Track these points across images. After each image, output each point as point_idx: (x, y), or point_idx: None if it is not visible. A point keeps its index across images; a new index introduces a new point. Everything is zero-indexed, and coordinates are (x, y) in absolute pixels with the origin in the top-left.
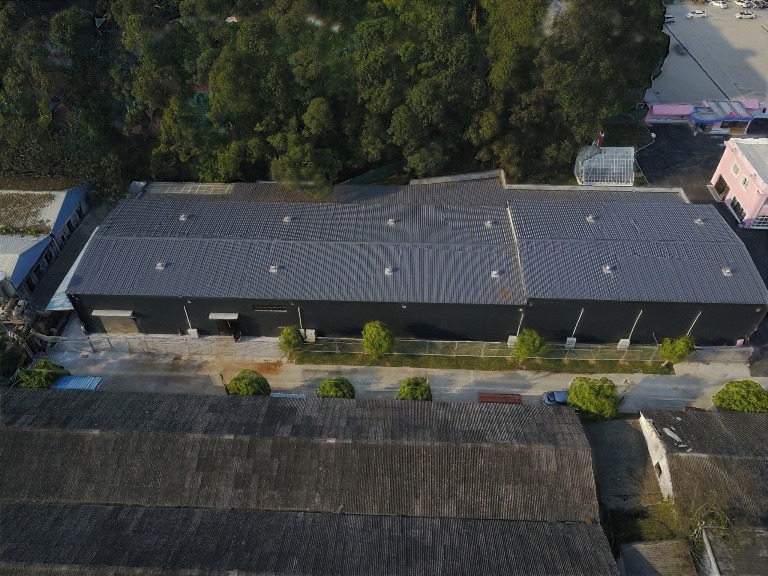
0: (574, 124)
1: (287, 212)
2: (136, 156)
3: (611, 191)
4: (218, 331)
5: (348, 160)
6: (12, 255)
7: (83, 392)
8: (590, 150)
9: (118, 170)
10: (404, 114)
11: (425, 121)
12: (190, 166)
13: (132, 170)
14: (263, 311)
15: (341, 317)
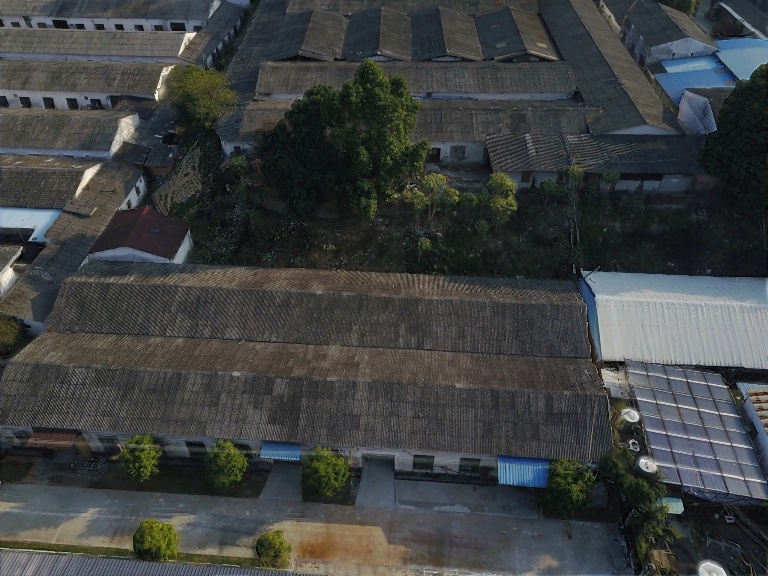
0: None
1: None
2: None
3: None
4: None
5: None
6: None
7: (505, 451)
8: None
9: None
10: None
11: None
12: None
13: None
14: None
15: None
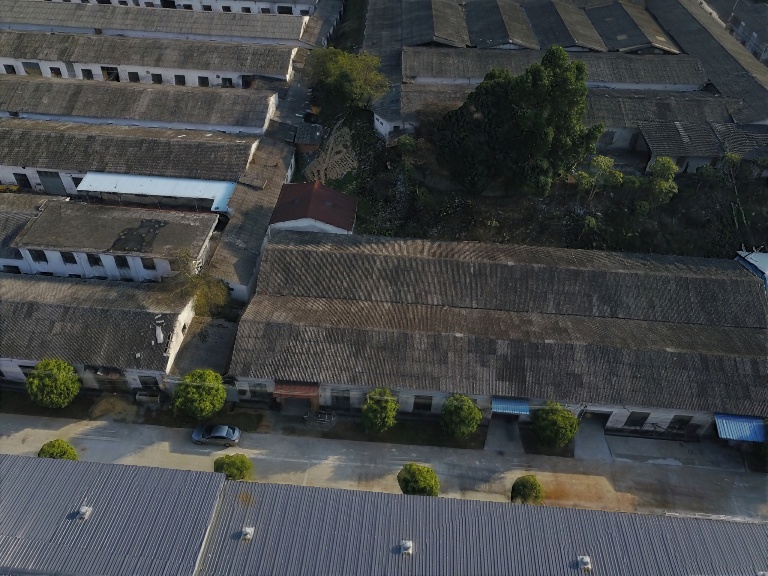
0: None
1: None
2: None
3: None
4: None
5: None
6: None
7: (721, 408)
8: None
9: None
10: None
11: None
12: None
13: None
14: None
15: None
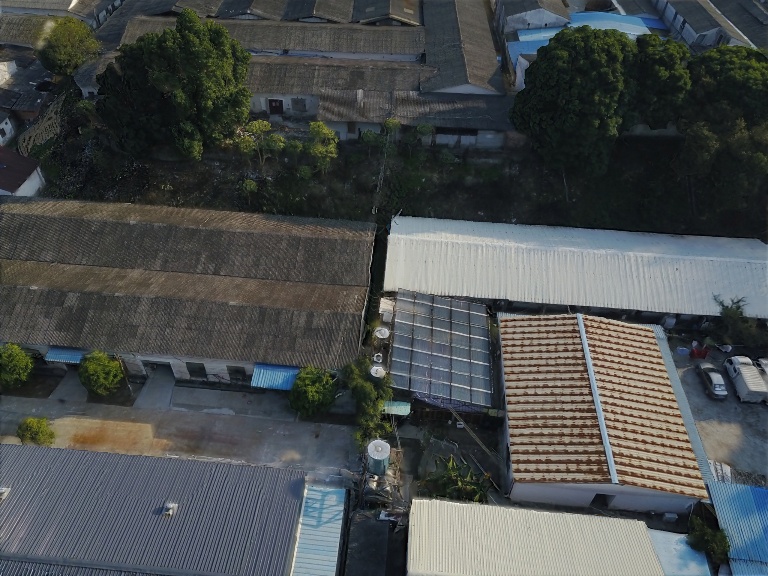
0: None
1: None
2: None
3: None
4: None
5: None
6: (419, 571)
7: (261, 359)
8: None
9: None
10: None
11: None
12: None
13: None
14: None
15: None
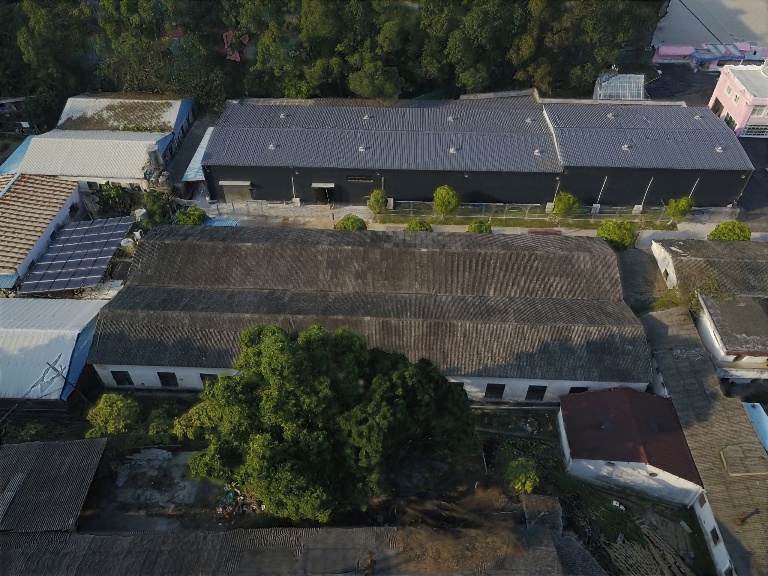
0: (596, 48)
1: (365, 113)
2: (230, 78)
3: (626, 104)
4: (316, 201)
5: (405, 84)
6: (150, 142)
7: (228, 227)
8: (608, 72)
9: (222, 84)
10: (459, 36)
11: (475, 42)
12: (278, 84)
13: (227, 89)
14: (354, 181)
15: (415, 186)
